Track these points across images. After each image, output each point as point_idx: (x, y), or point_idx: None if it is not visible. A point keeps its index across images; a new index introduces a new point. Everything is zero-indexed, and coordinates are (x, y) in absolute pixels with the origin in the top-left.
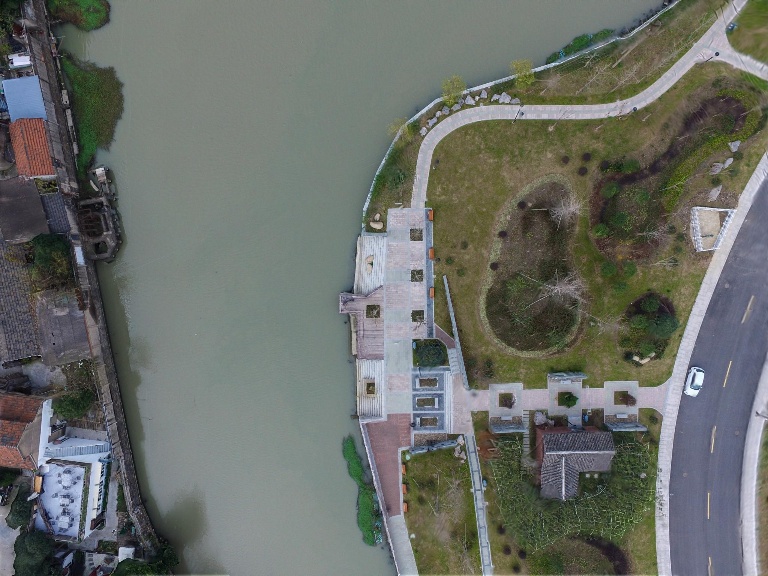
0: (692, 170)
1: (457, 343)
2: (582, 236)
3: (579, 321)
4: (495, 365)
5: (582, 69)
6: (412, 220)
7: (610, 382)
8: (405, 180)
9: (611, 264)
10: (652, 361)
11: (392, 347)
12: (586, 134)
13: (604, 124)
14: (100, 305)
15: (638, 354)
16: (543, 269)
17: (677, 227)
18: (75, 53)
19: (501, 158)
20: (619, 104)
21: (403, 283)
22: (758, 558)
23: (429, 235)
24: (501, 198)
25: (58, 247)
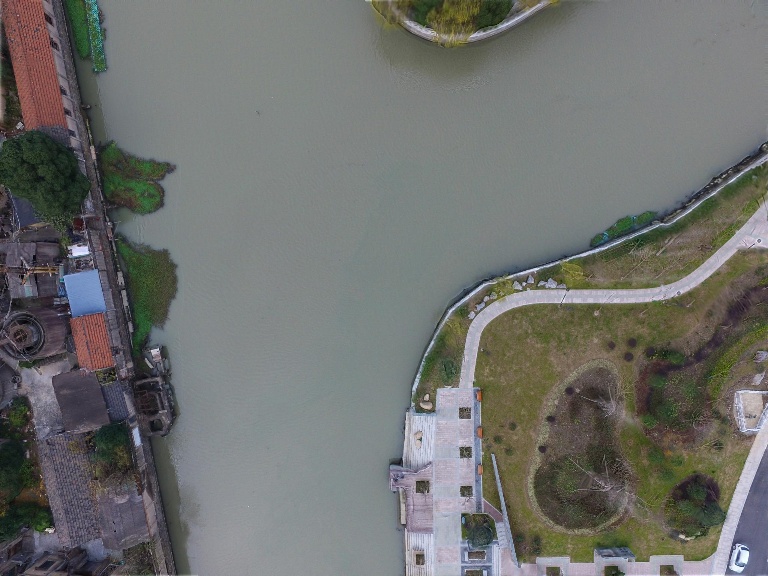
0: (736, 358)
1: (506, 522)
2: (628, 420)
3: (626, 501)
4: (543, 541)
5: (627, 255)
6: (460, 399)
7: (656, 556)
8: (454, 362)
9: (657, 448)
10: (697, 537)
11: (441, 521)
12: (631, 318)
13: (649, 309)
14: (155, 478)
15: (684, 533)
16: (591, 454)
17: (722, 411)
18: (130, 236)
19: (548, 343)
20: (663, 289)
21: (452, 460)
22: None
23: (477, 414)
24: (549, 383)
25: (119, 440)
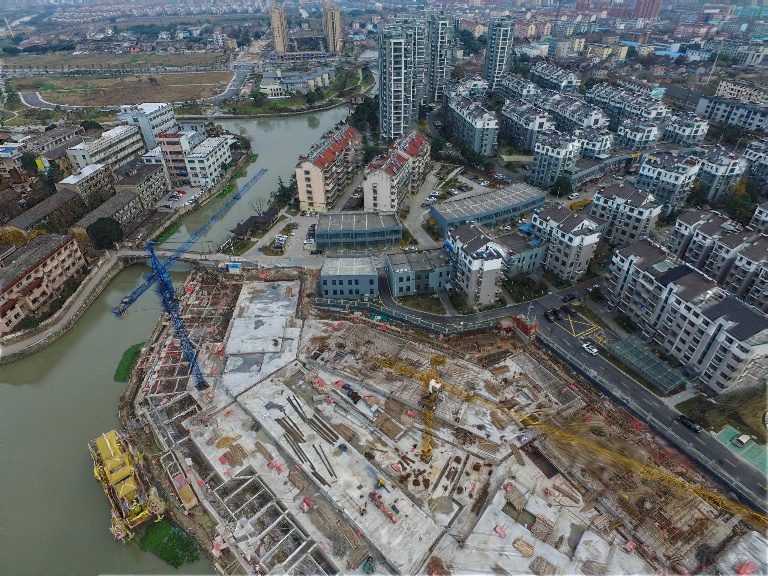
0: None
1: None
2: None
3: None
4: None
5: None
6: None
7: None
8: None
9: None
10: None
11: None
12: None
13: None
14: None
15: None
16: None
17: None
18: None
19: None
20: None
21: None
22: None
23: None
24: None
25: None
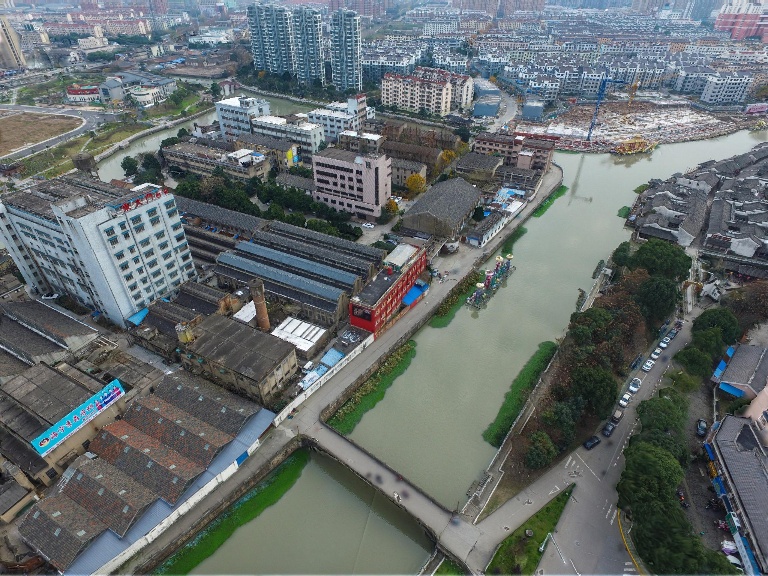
0: None
1: None
2: None
3: None
4: None
5: None
6: None
7: None
8: None
9: None
10: None
11: None
12: None
13: None
14: None
15: None
16: None
17: None
18: None
19: None
20: None
21: None
22: (4, 155)
23: None
24: None
25: None
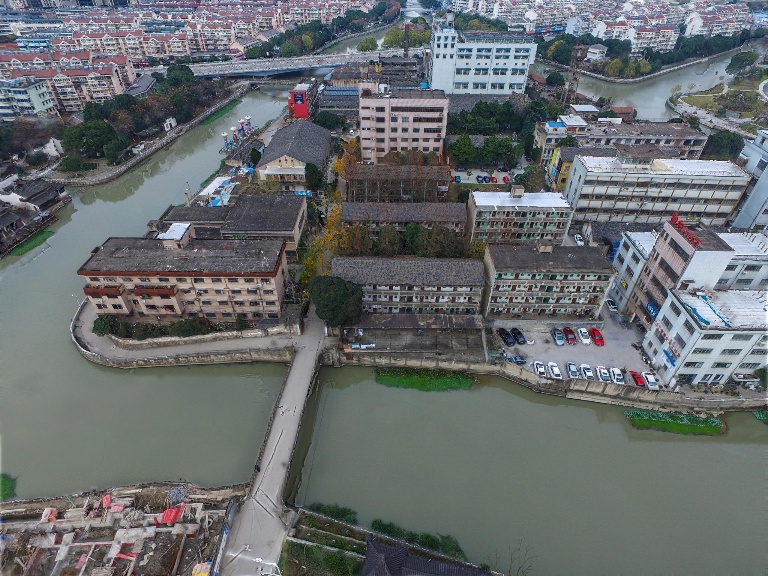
0: None
1: (726, 112)
2: None
3: None
4: None
5: None
6: None
7: None
8: (678, 101)
9: None
10: None
11: None
12: None
13: None
14: None
15: None
16: None
17: None
18: None
19: None
20: None
21: None
22: None
23: None
24: None
25: None
